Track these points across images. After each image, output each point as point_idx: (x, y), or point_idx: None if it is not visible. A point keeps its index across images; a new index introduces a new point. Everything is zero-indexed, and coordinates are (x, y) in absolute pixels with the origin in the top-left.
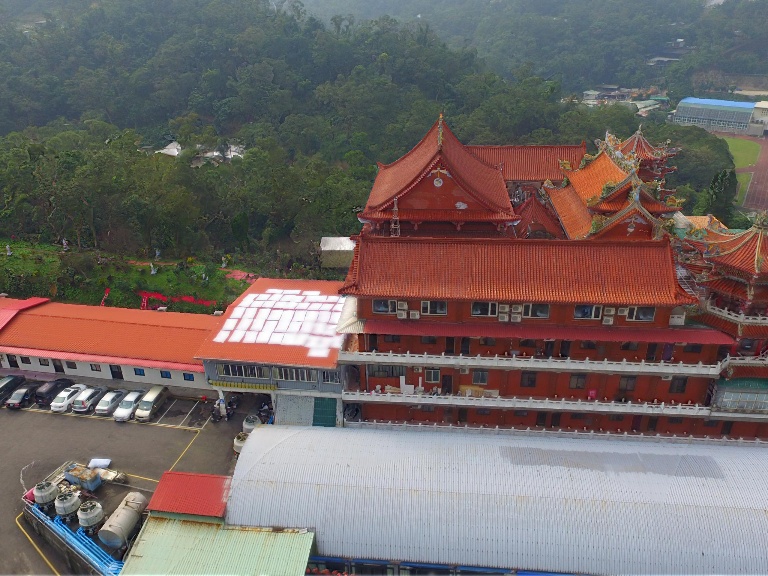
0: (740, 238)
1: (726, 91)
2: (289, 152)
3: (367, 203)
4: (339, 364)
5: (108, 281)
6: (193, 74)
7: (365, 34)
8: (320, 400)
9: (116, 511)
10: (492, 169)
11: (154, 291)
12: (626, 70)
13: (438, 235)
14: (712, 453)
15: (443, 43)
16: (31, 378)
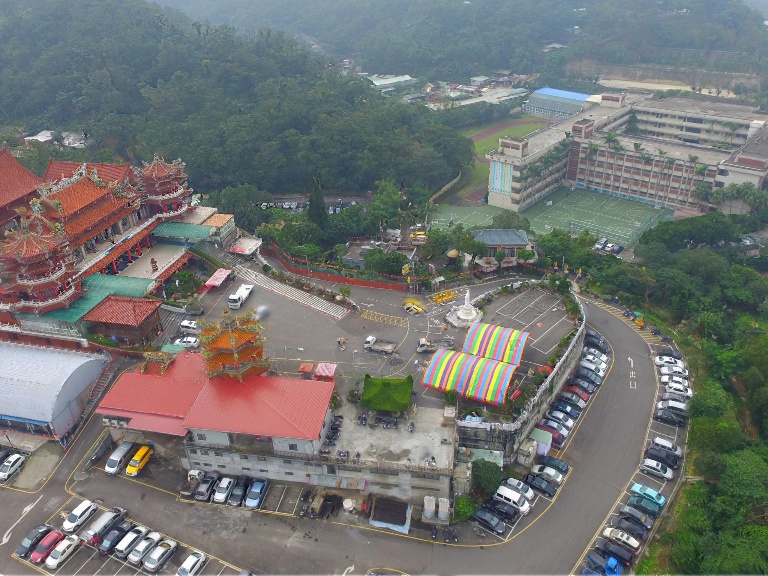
0: None
1: (591, 81)
2: None
3: None
4: None
5: None
6: (63, 75)
7: (208, 40)
8: None
9: None
10: (40, 182)
11: None
12: (516, 57)
13: None
14: None
15: (280, 46)
16: None
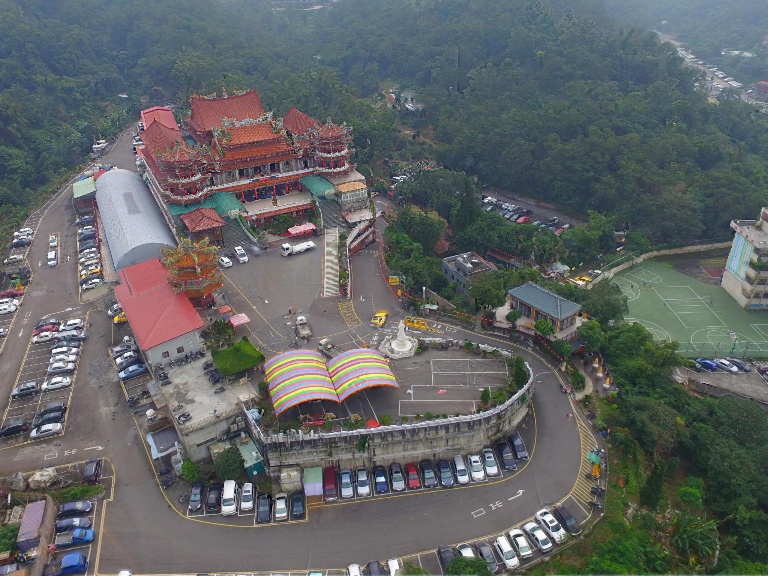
0: None
1: None
2: None
3: None
4: None
5: None
6: (439, 48)
7: (564, 32)
8: None
9: None
10: None
11: None
12: None
13: None
14: (144, 214)
15: (634, 48)
16: None
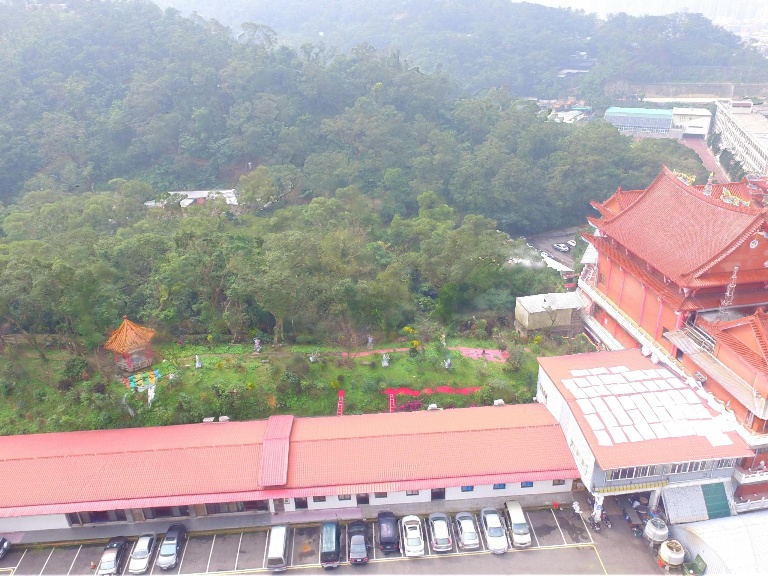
0: None
1: (636, 99)
2: (304, 192)
3: (660, 269)
4: (752, 450)
5: (338, 382)
6: (177, 114)
7: (345, 62)
8: (707, 487)
9: None
10: None
11: (399, 386)
12: (543, 83)
13: (747, 295)
14: None
15: (417, 68)
16: (334, 518)
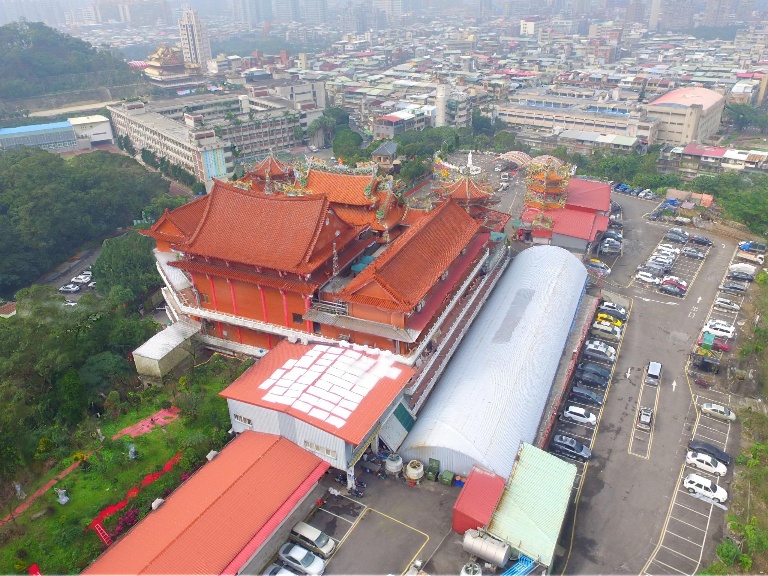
0: (463, 184)
1: (21, 116)
2: None
3: (276, 267)
4: None
5: None
6: None
7: None
8: (396, 412)
9: (487, 544)
10: None
11: (99, 511)
12: None
13: None
14: None
15: None
16: None
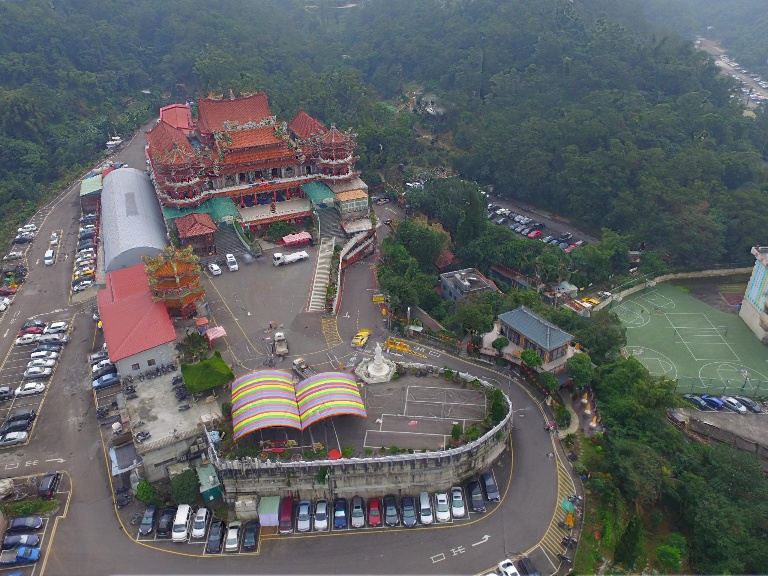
0: None
1: None
2: None
3: None
4: None
5: None
6: (465, 51)
7: (594, 38)
8: None
9: (100, 168)
10: None
11: None
12: None
13: None
14: None
15: (666, 56)
16: None
